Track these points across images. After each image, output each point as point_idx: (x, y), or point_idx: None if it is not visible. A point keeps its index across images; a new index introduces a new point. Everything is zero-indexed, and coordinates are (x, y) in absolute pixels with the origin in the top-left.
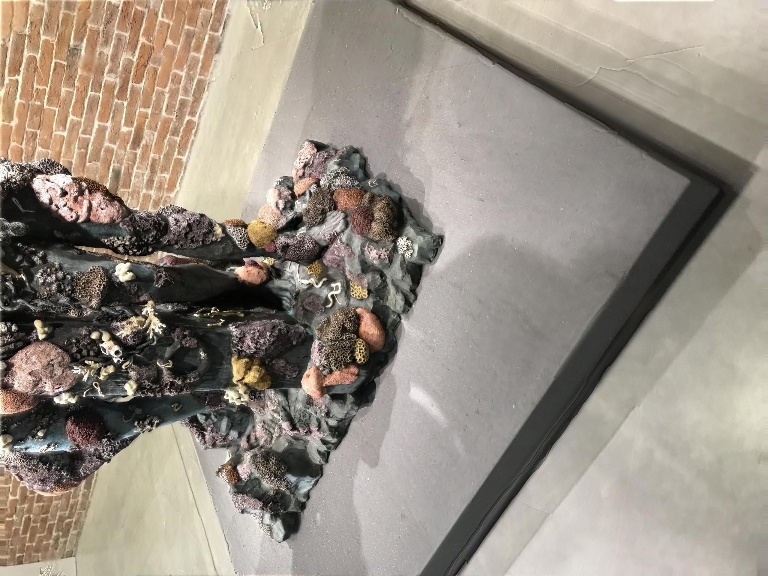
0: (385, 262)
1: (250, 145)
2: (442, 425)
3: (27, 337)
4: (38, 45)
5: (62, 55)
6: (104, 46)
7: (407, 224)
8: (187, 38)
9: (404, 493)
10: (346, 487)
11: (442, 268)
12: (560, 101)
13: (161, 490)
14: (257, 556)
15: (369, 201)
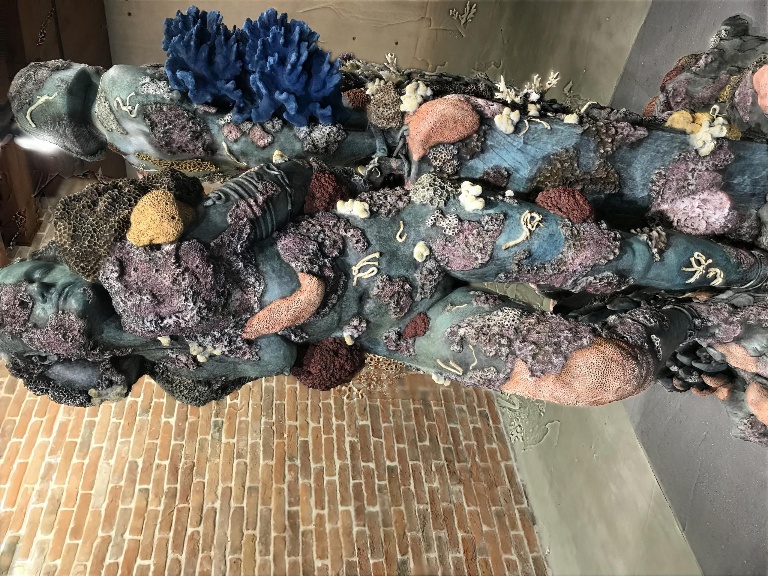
0: (716, 51)
1: (612, 482)
2: None
3: None
4: (369, 571)
5: (394, 575)
6: (429, 549)
7: None
8: (499, 518)
9: None
10: None
11: (757, 8)
12: None
13: None
14: None
15: None
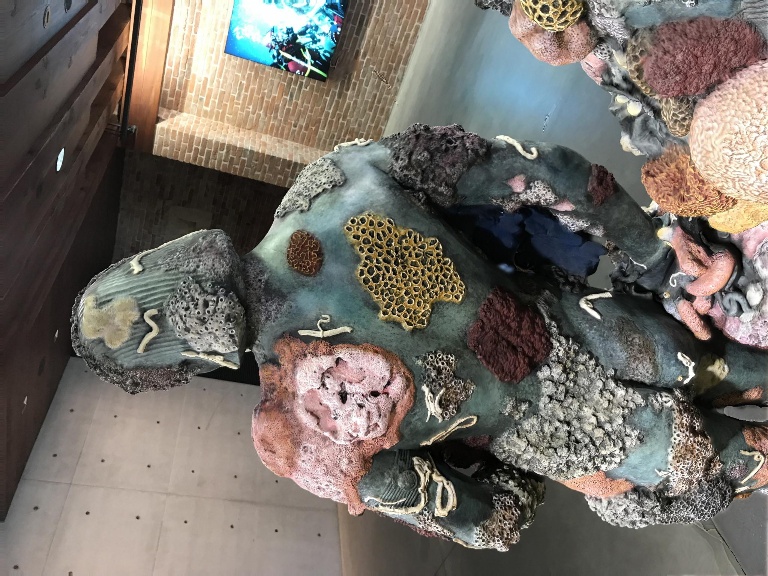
0: None
1: None
2: None
3: None
4: None
5: None
6: None
7: None
8: None
9: None
10: None
11: None
12: None
13: None
14: None
15: None
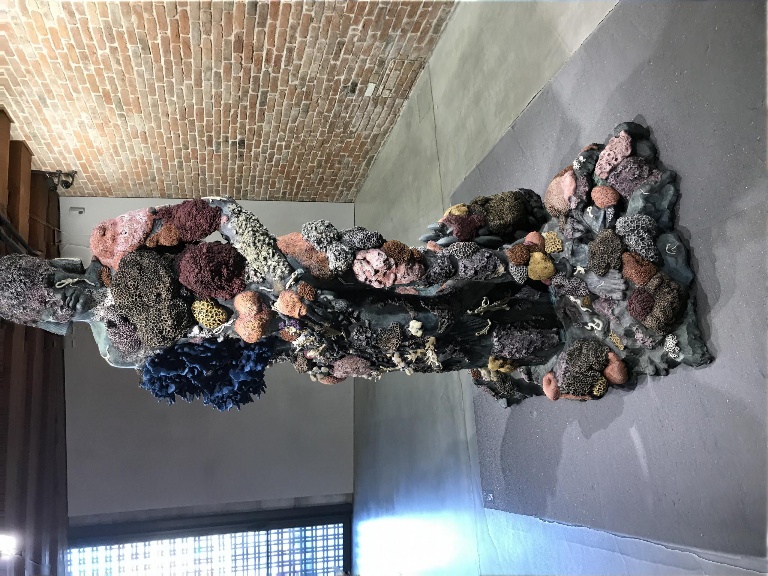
0: (648, 347)
1: None
2: (645, 478)
3: (343, 354)
4: None
5: None
6: None
7: (685, 320)
8: None
9: (600, 478)
10: (561, 423)
11: (700, 380)
12: None
13: (424, 228)
14: None
15: (655, 289)
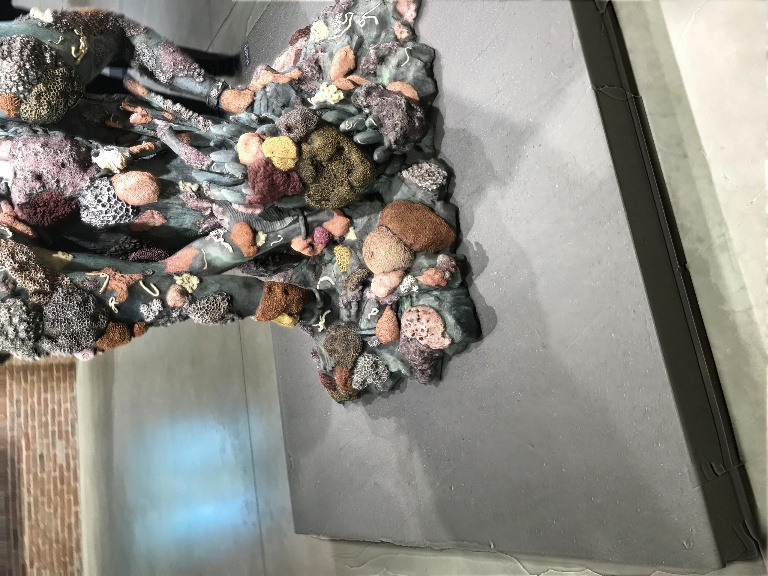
0: None
1: None
2: None
3: None
4: None
5: None
6: None
7: None
8: None
9: None
10: None
11: None
12: (341, 539)
13: None
14: (303, 2)
15: None
